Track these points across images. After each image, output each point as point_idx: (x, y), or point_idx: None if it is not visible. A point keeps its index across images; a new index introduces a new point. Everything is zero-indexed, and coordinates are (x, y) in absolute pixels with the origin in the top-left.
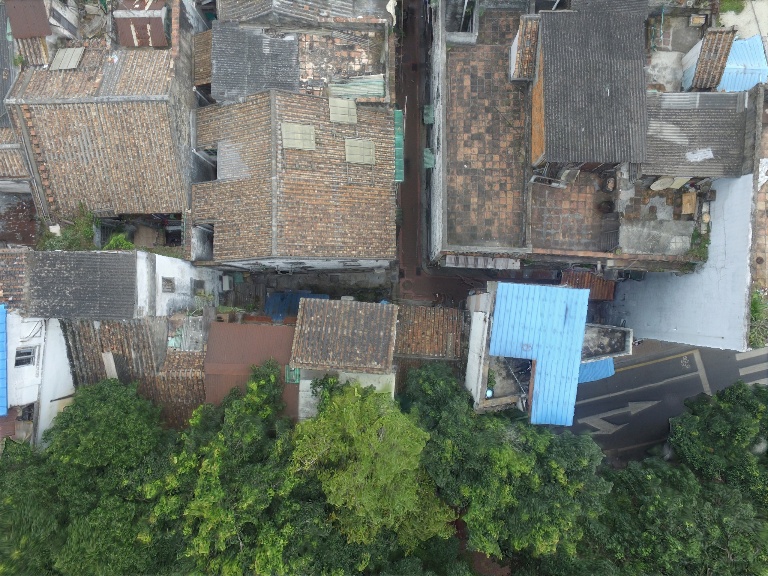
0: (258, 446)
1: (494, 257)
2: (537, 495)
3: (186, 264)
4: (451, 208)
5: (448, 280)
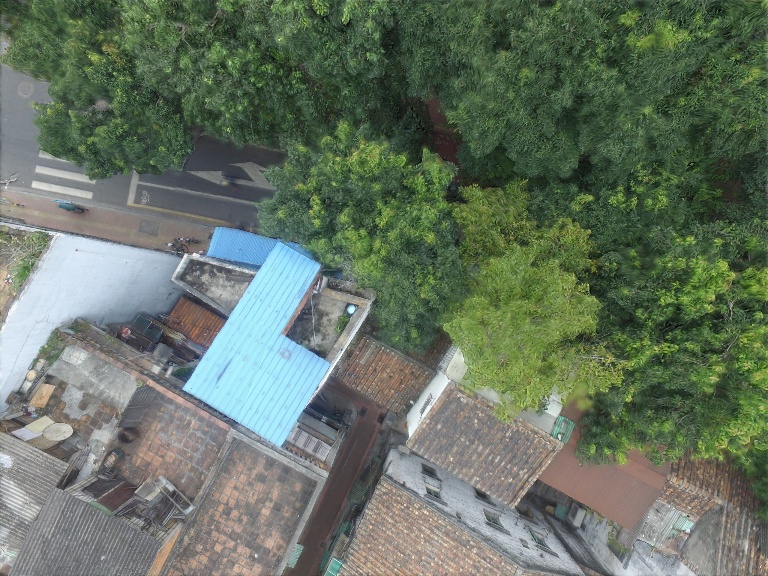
0: (649, 389)
1: None
2: (353, 198)
3: None
4: (295, 515)
5: (337, 388)
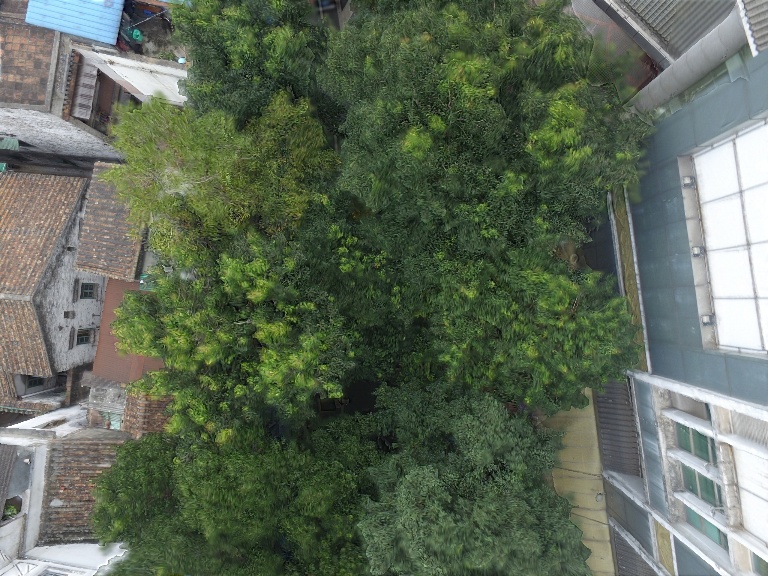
0: None
1: (78, 63)
2: None
3: (59, 411)
4: None
5: None
